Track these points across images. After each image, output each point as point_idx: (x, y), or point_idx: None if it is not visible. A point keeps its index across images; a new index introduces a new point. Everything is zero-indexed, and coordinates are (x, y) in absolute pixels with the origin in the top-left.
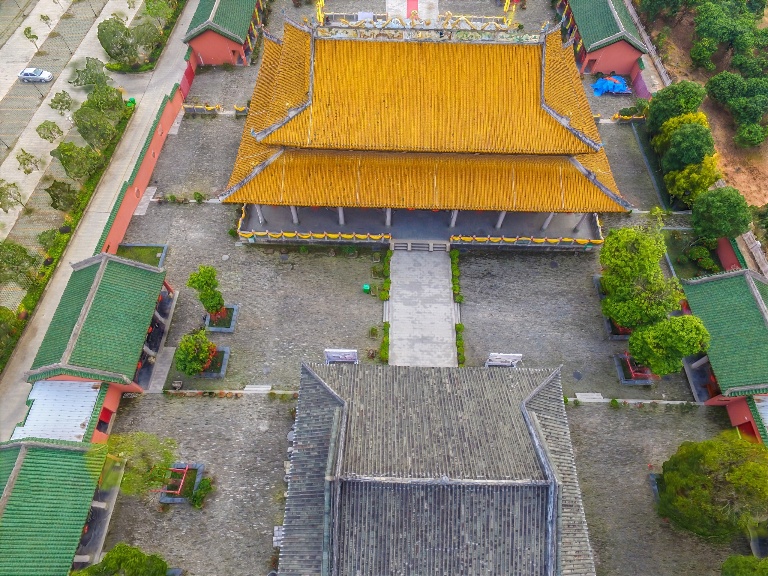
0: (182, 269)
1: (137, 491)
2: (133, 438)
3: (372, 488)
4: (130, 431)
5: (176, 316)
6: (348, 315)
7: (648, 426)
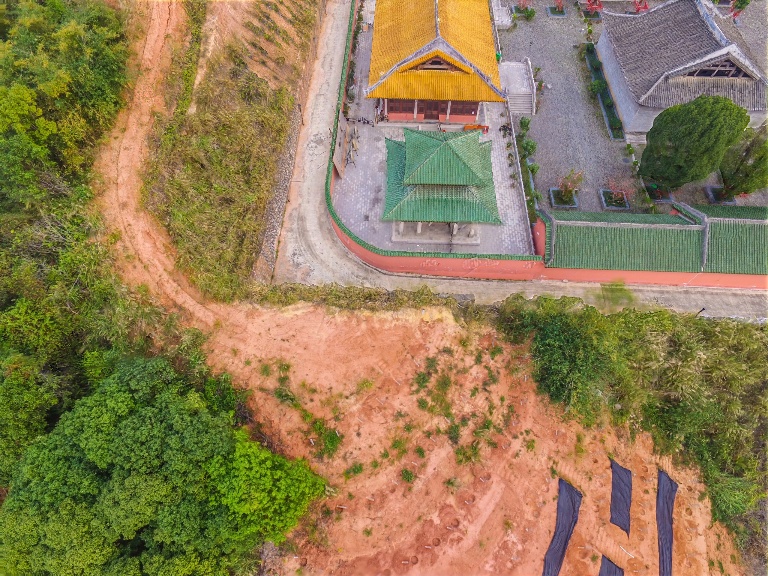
0: (750, 6)
1: (627, 7)
2: (649, 2)
3: (692, 6)
4: (652, 1)
5: (719, 8)
6: (762, 68)
7: (765, 197)
